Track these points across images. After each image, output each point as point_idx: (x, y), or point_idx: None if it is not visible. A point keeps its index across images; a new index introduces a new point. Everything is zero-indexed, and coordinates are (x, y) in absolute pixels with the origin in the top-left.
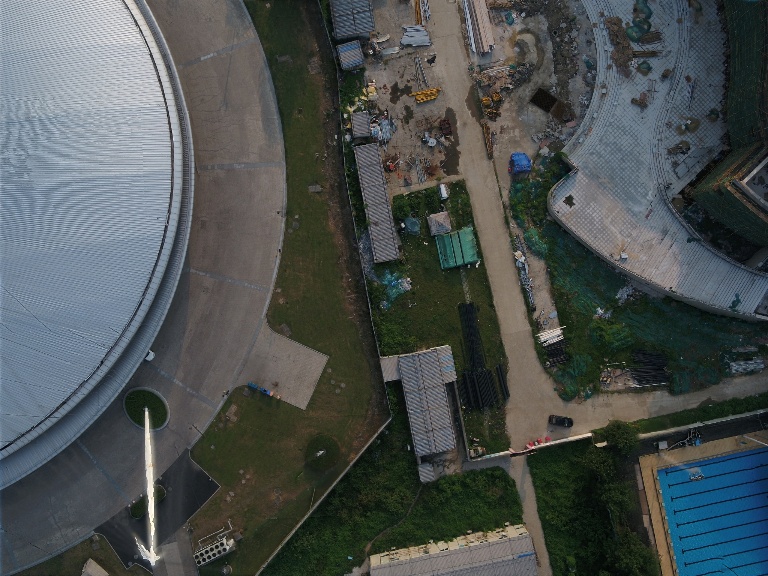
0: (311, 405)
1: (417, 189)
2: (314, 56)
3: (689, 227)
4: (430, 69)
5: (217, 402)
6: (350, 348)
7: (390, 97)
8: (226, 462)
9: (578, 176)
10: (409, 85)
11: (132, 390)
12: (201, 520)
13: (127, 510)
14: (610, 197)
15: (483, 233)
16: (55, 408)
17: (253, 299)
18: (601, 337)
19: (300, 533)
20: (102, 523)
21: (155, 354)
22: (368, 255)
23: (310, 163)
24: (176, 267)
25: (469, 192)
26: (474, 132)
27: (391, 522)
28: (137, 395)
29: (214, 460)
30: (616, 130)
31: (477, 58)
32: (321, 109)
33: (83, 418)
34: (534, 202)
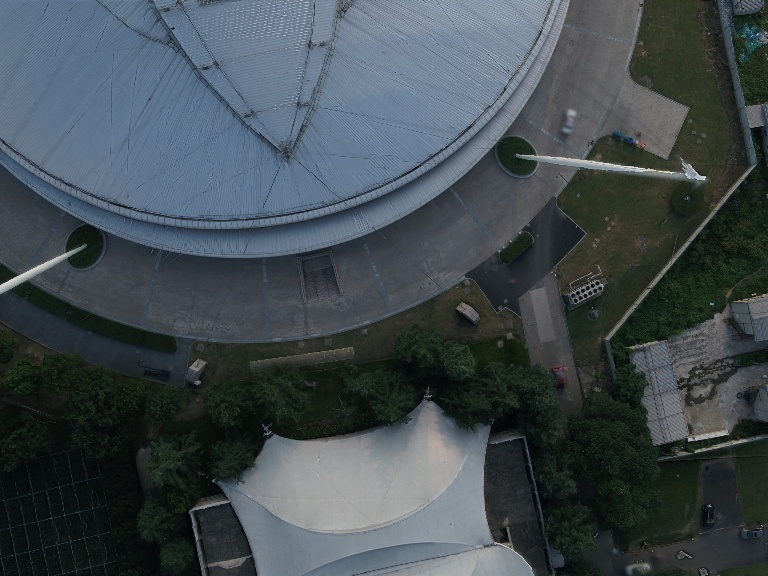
0: (673, 155)
1: None
2: None
3: None
4: None
5: (582, 151)
6: (710, 100)
7: None
8: (592, 209)
9: None
10: None
11: (504, 137)
12: (568, 266)
13: (496, 256)
14: None
15: None
16: (462, 131)
17: (616, 52)
18: None
19: (666, 277)
20: (473, 268)
21: None
22: (728, 8)
23: None
24: (563, 6)
25: None
26: None
27: (752, 269)
28: (510, 141)
29: (580, 208)
30: None
31: None
32: None
33: (475, 151)
34: None
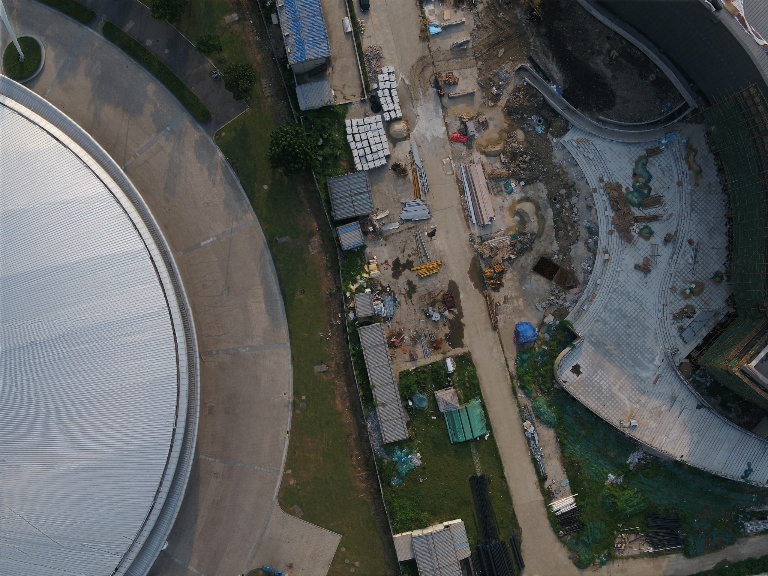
0: None
1: (423, 364)
2: (314, 236)
3: (698, 395)
4: (431, 242)
5: None
6: (363, 526)
7: (392, 272)
8: None
9: (584, 344)
10: (410, 260)
11: None
12: None
13: None
14: (617, 364)
15: (491, 404)
16: None
17: (263, 482)
18: (614, 504)
19: None
20: None
21: (168, 542)
22: (377, 433)
23: (315, 343)
24: (186, 464)
25: (475, 364)
26: (478, 303)
27: None
28: None
29: None
30: (620, 296)
31: (477, 229)
32: (323, 289)
33: None
34: (541, 371)
